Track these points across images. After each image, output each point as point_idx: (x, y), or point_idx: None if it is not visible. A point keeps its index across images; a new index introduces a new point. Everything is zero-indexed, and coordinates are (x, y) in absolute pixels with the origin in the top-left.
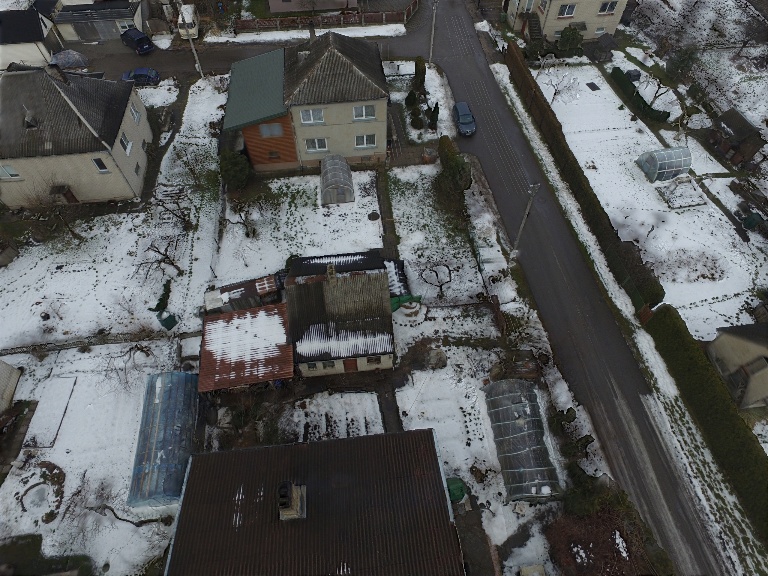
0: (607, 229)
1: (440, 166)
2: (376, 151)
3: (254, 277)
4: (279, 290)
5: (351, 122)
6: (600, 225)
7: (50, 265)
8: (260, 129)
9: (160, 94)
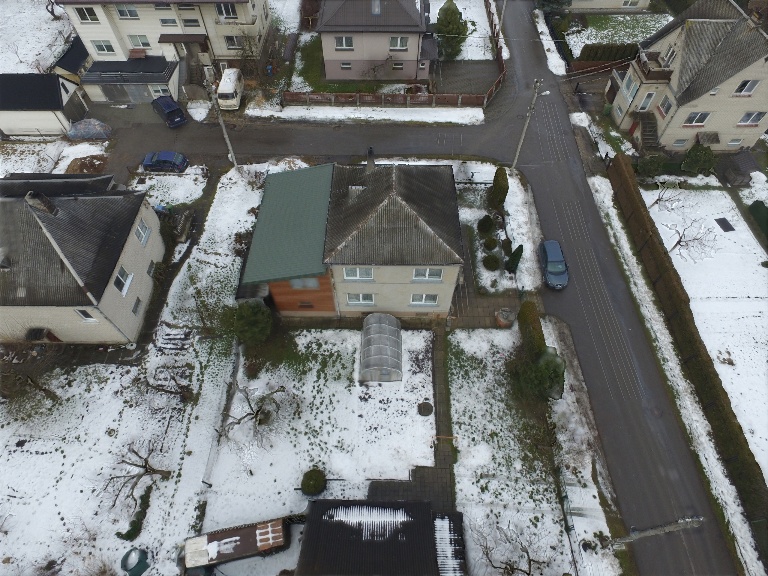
0: (760, 494)
1: (518, 335)
2: (436, 309)
3: (259, 495)
4: (289, 525)
5: (409, 282)
6: (747, 480)
7: (10, 438)
8: (290, 280)
9: (184, 185)
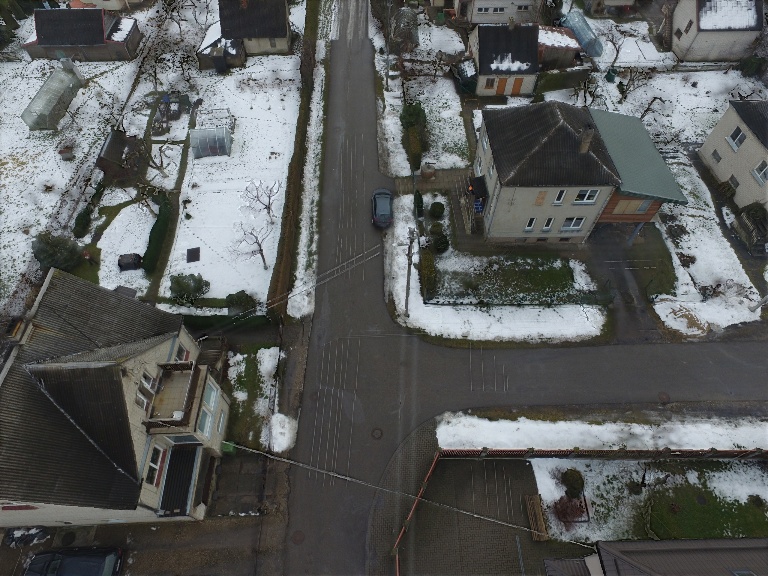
0: None
1: None
2: None
3: (565, 99)
4: None
5: None
6: None
7: None
8: None
9: None
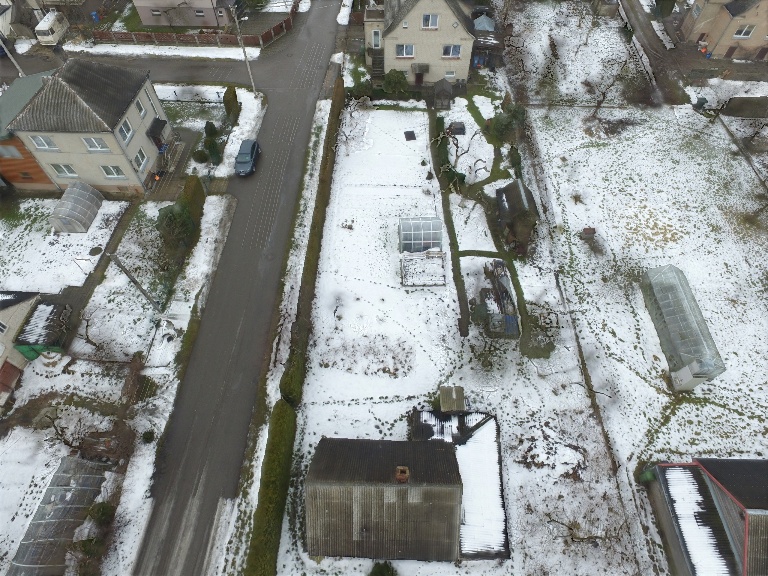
0: None
1: None
2: (129, 182)
3: None
4: None
5: (87, 152)
6: None
7: None
8: None
9: None
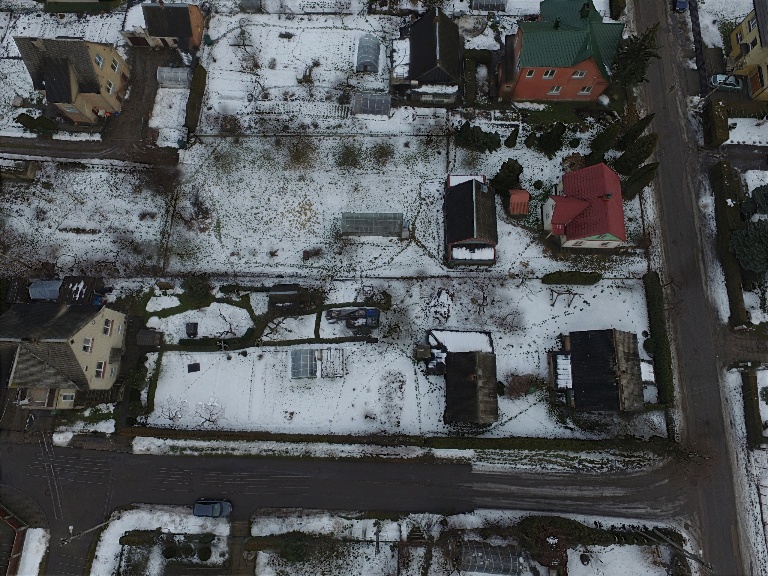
0: None
1: None
2: None
3: None
4: None
5: None
6: None
7: None
8: None
9: None
